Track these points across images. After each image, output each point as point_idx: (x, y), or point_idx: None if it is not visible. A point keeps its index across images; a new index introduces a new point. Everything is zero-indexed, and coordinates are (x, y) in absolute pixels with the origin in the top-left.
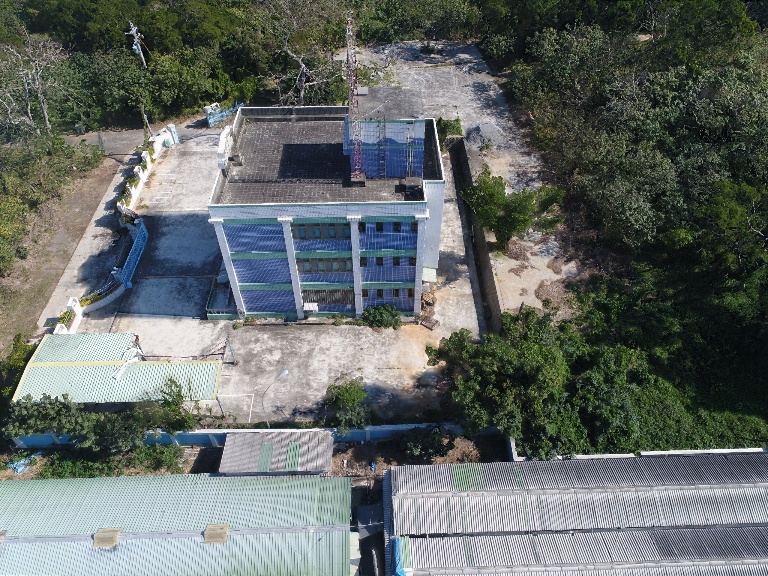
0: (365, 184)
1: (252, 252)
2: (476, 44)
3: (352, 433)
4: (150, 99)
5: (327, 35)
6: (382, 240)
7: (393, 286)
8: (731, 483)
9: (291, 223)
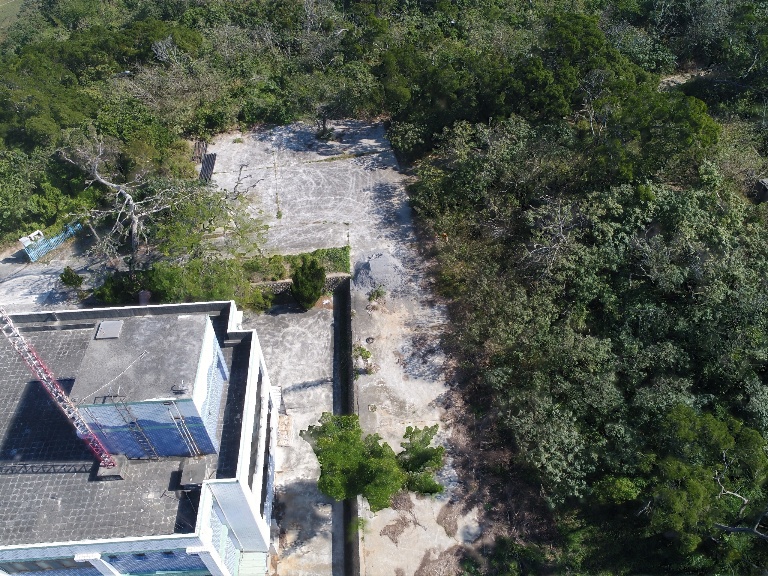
0: (122, 476)
1: None
2: (385, 124)
3: None
4: None
5: (198, 121)
6: (151, 564)
7: None
8: None
9: None
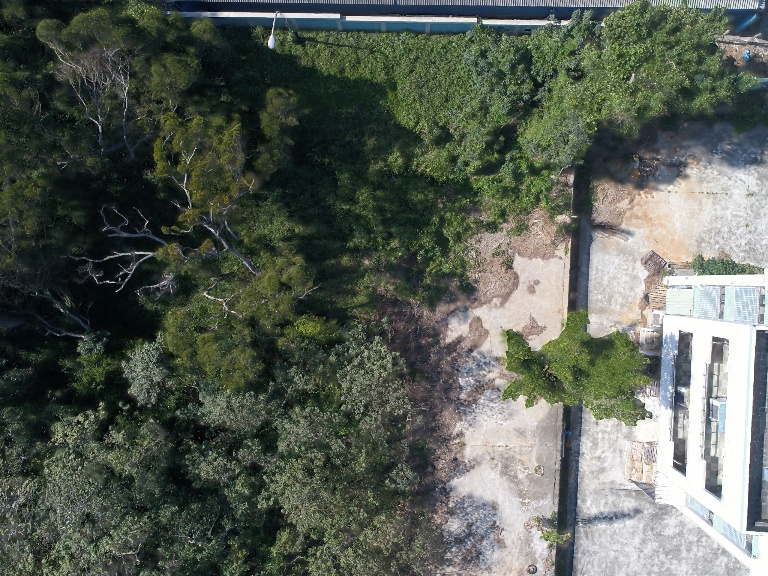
0: None
1: None
2: None
3: None
4: None
5: None
6: None
7: None
8: None
9: None
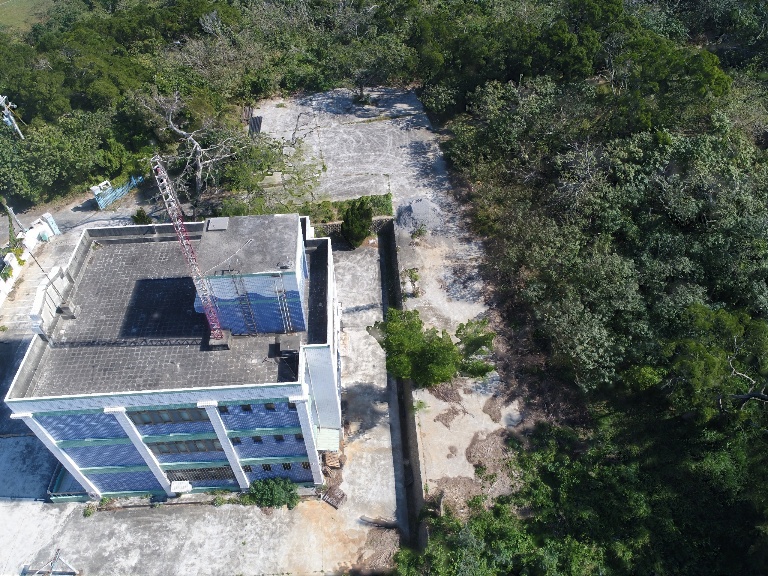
0: (229, 346)
1: (85, 440)
2: (417, 90)
3: None
4: (27, 180)
5: (245, 87)
6: (254, 420)
7: (281, 461)
8: None
9: (126, 411)
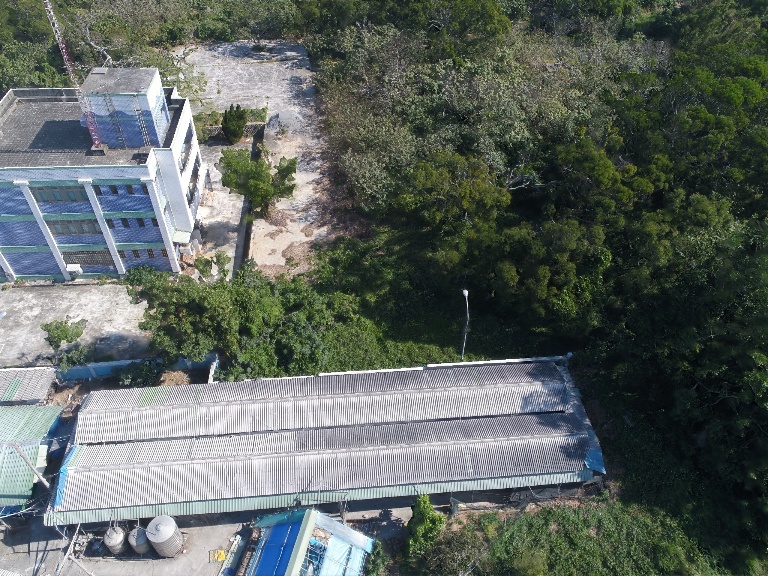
0: (105, 153)
1: (2, 215)
2: None
3: (77, 370)
4: None
5: (162, 33)
6: (120, 202)
7: (145, 247)
8: (375, 391)
9: (29, 186)
